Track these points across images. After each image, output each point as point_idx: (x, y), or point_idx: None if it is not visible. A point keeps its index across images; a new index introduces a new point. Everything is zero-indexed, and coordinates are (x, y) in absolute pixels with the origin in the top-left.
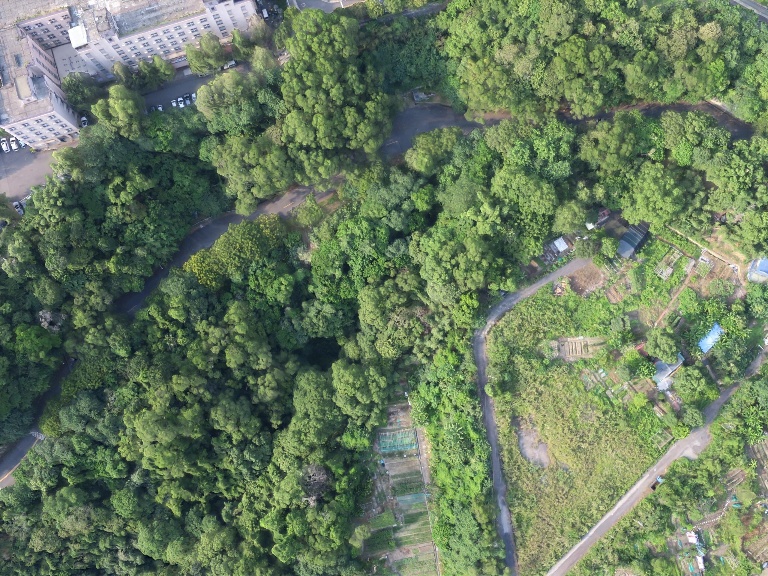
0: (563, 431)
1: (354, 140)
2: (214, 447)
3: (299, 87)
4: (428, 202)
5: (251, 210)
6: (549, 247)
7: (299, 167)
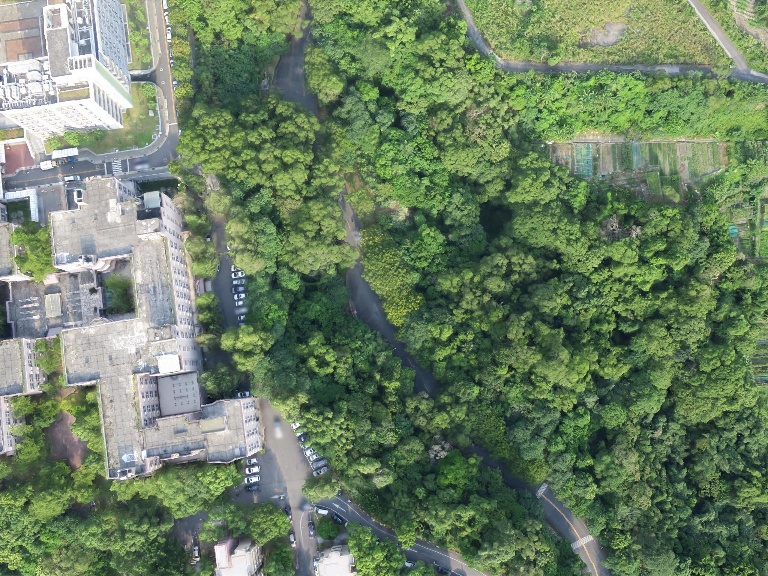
0: (597, 5)
1: (309, 133)
2: (571, 324)
3: (255, 164)
4: (373, 87)
5: (355, 250)
6: None
7: (322, 195)
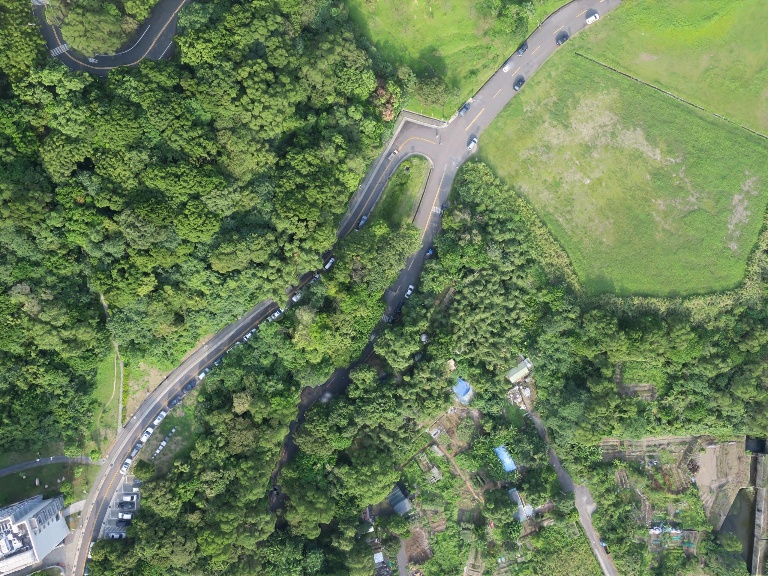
0: None
1: None
2: None
3: None
4: None
5: None
6: (375, 570)
7: None
